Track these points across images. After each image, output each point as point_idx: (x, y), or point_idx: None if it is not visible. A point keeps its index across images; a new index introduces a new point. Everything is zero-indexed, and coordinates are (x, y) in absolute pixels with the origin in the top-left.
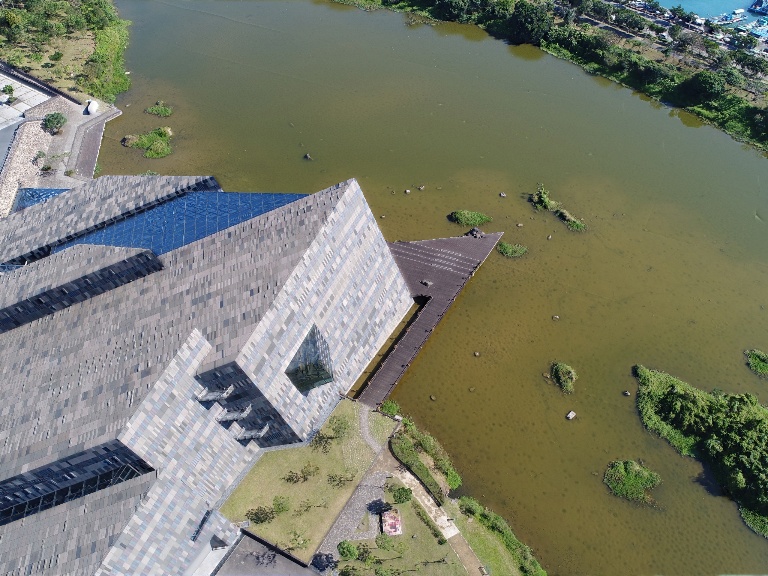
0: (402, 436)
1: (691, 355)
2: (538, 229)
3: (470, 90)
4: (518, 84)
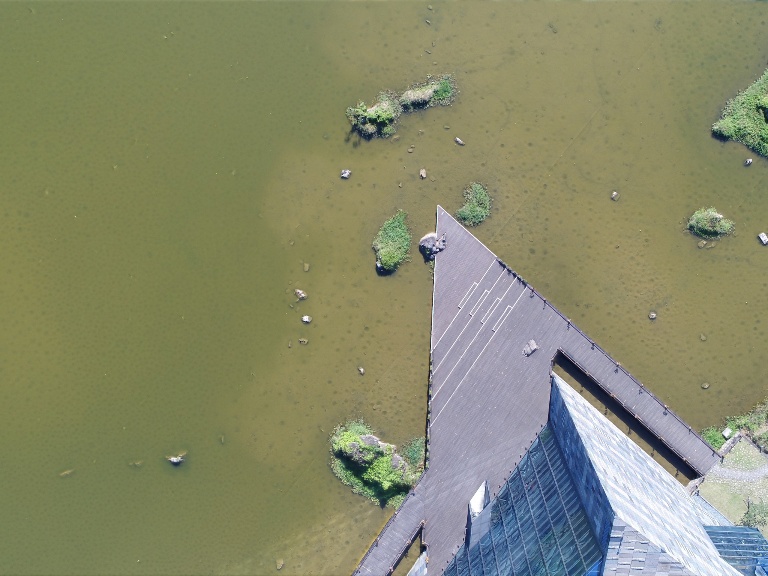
0: (763, 438)
1: (709, 56)
2: (437, 151)
3: (4, 122)
4: (0, 22)
